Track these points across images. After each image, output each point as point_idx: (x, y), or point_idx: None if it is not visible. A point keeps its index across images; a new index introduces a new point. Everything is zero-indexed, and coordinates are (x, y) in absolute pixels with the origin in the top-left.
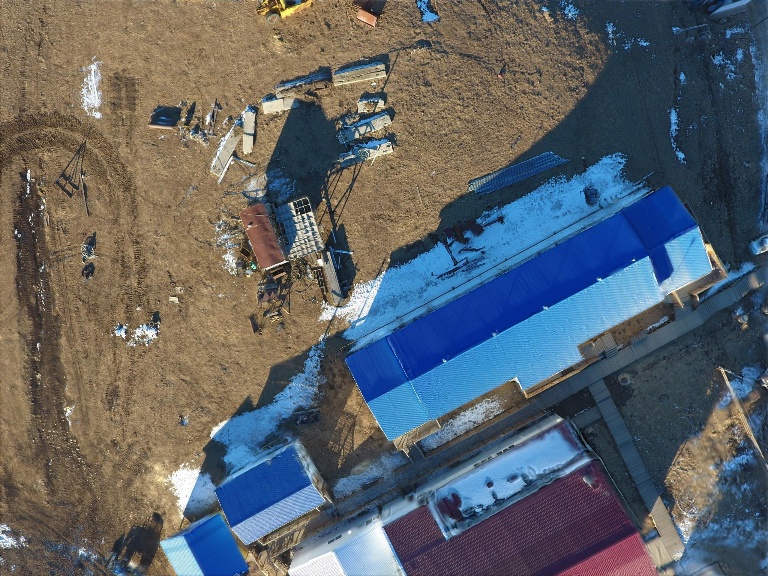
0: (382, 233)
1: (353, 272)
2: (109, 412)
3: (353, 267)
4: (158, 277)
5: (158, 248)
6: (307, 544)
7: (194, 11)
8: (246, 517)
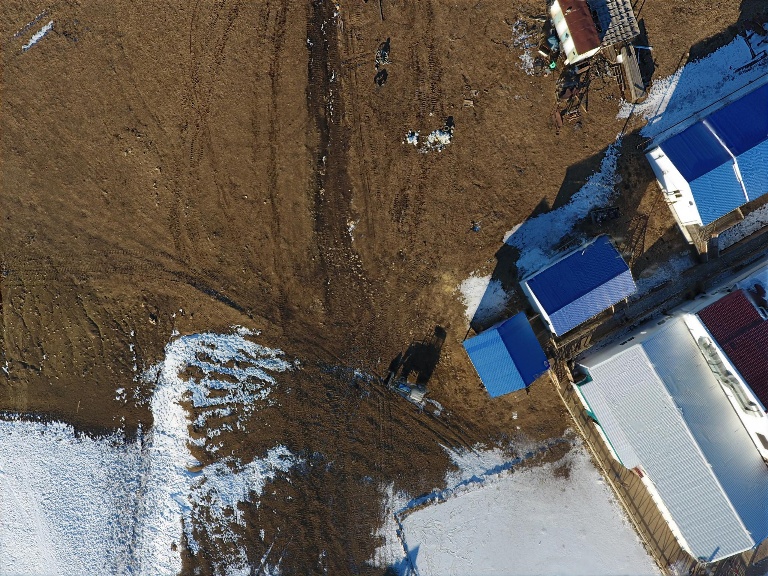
0: (682, 27)
1: (652, 68)
2: (397, 223)
3: (652, 63)
4: (453, 81)
5: (453, 52)
6: (590, 354)
7: None
8: (563, 304)
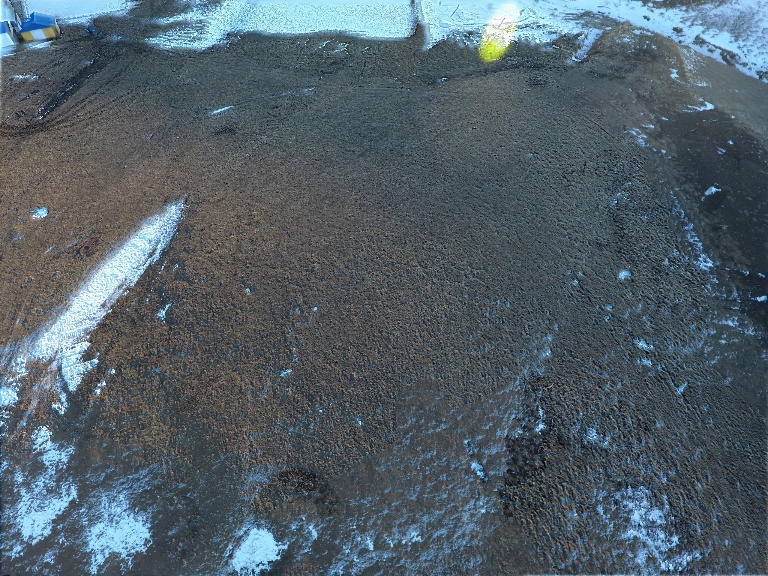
0: None
1: None
2: None
3: None
4: None
5: None
6: None
7: None
8: None
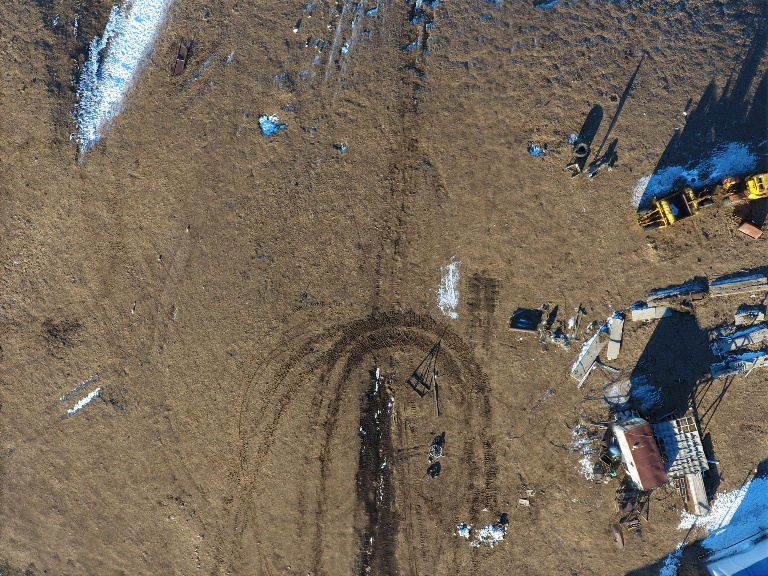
0: (751, 444)
1: (717, 481)
2: None
3: (717, 477)
4: (508, 479)
5: (510, 450)
6: None
7: (562, 215)
8: None
